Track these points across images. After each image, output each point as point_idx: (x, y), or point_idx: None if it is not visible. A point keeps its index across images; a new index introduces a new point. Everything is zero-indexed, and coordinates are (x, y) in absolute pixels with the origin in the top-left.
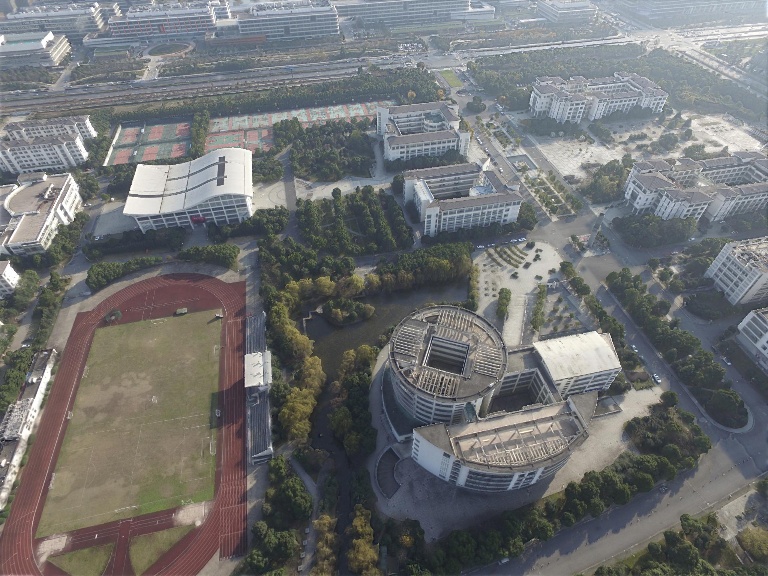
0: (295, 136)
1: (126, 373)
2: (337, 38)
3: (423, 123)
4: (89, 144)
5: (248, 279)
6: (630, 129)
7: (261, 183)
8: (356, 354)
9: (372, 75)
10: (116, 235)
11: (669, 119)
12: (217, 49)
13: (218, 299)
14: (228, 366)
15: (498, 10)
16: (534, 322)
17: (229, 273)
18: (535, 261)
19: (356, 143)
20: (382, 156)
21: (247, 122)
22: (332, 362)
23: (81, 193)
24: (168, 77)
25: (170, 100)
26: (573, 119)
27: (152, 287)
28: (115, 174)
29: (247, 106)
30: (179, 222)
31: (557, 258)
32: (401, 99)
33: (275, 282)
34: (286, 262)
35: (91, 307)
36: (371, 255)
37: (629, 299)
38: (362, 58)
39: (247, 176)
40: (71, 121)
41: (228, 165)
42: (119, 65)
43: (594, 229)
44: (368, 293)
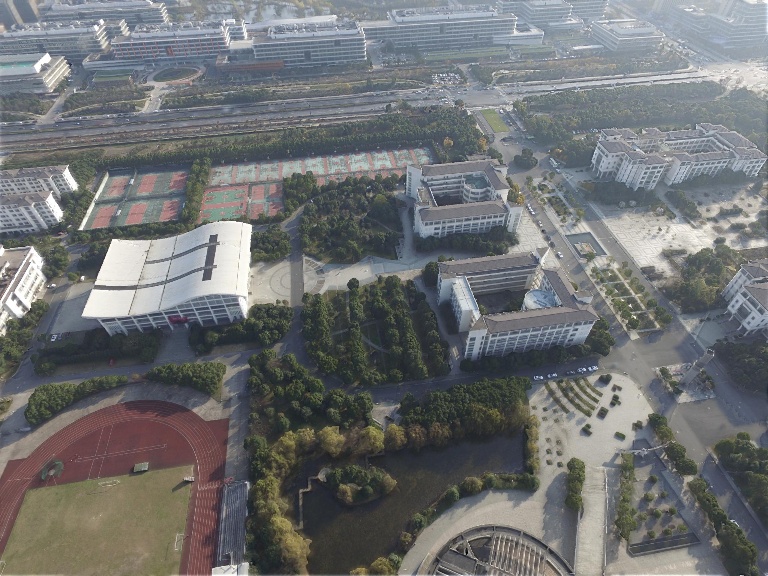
0: (308, 196)
1: (53, 575)
2: (364, 65)
3: (463, 186)
4: (66, 200)
5: (233, 416)
6: (718, 199)
7: (262, 263)
8: (368, 574)
9: (402, 114)
10: (78, 334)
11: (767, 186)
12: (229, 75)
13: (191, 448)
14: (191, 573)
15: (546, 33)
16: (621, 525)
17: (209, 404)
18: (613, 406)
19: (380, 210)
20: (411, 228)
21: (253, 173)
22: (335, 574)
23: (44, 271)
24: (171, 110)
25: (169, 140)
26: (647, 184)
27: (109, 422)
28: (89, 244)
29: (255, 152)
30: (154, 322)
31: (642, 402)
32: (436, 148)
33: (267, 424)
34: (283, 396)
35: (27, 452)
36: (394, 384)
37: (755, 490)
38: (391, 91)
39: (242, 264)
40: (45, 173)
41: (220, 248)
42: (119, 93)
43: (695, 367)
44: (388, 448)
